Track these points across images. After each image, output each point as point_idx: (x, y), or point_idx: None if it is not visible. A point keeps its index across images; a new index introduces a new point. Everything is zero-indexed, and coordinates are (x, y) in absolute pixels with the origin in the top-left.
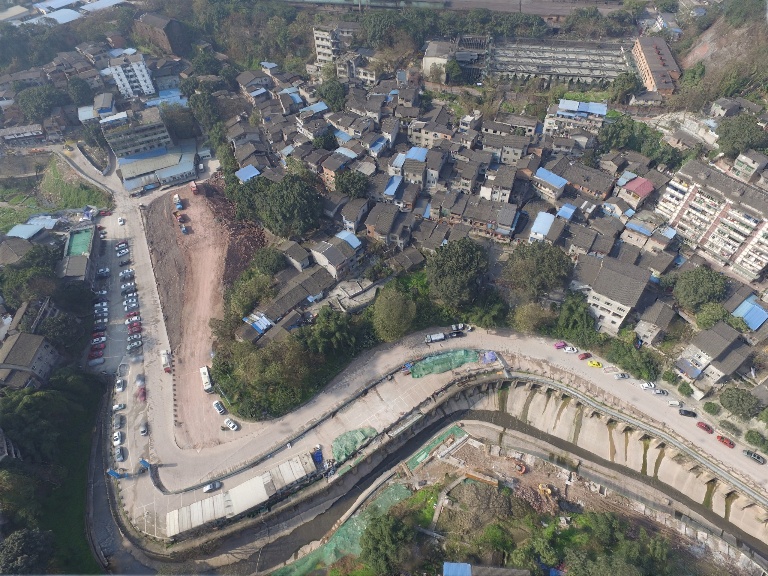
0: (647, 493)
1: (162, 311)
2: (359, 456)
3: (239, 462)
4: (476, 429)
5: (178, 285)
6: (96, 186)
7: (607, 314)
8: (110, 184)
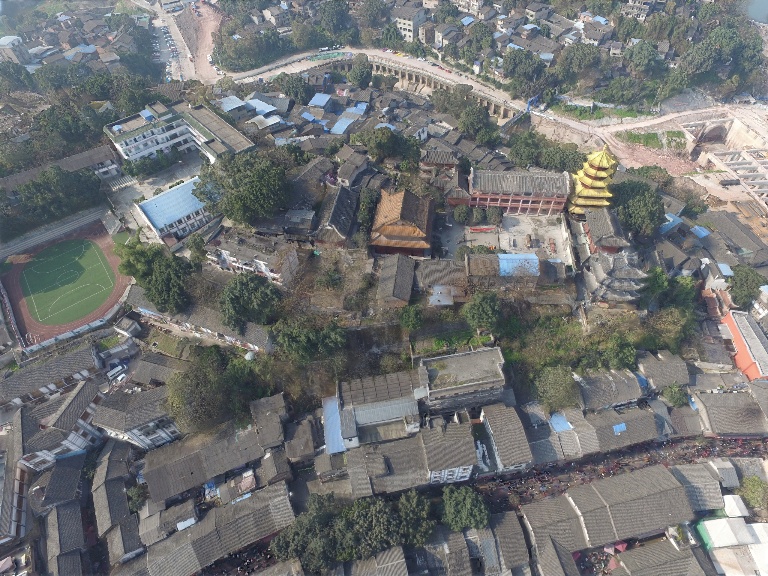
0: None
1: (187, 46)
2: None
3: None
4: None
5: (195, 34)
6: (146, 9)
7: (406, 32)
8: (154, 9)
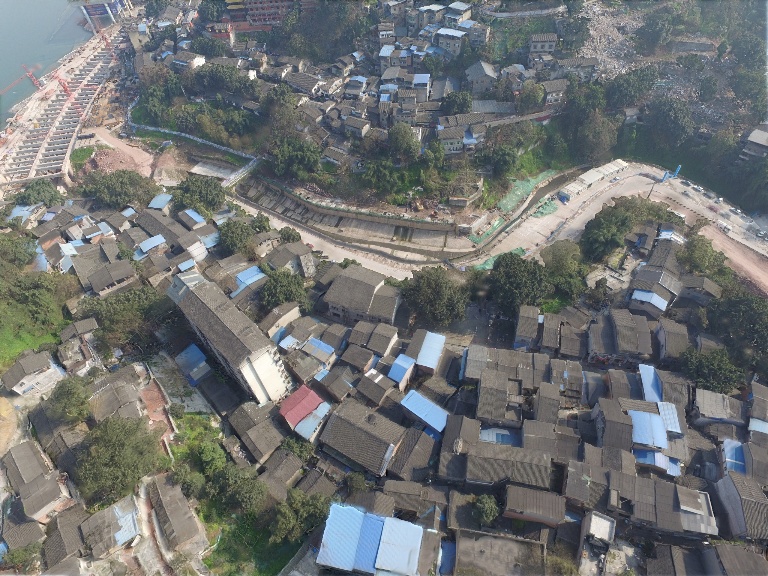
0: (352, 232)
1: None
2: (537, 207)
3: (610, 191)
4: (463, 245)
5: None
6: None
7: None
8: None
